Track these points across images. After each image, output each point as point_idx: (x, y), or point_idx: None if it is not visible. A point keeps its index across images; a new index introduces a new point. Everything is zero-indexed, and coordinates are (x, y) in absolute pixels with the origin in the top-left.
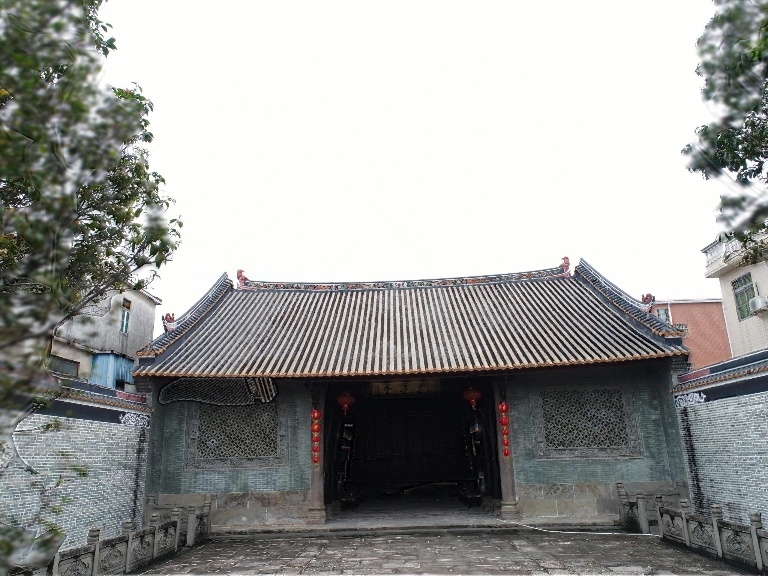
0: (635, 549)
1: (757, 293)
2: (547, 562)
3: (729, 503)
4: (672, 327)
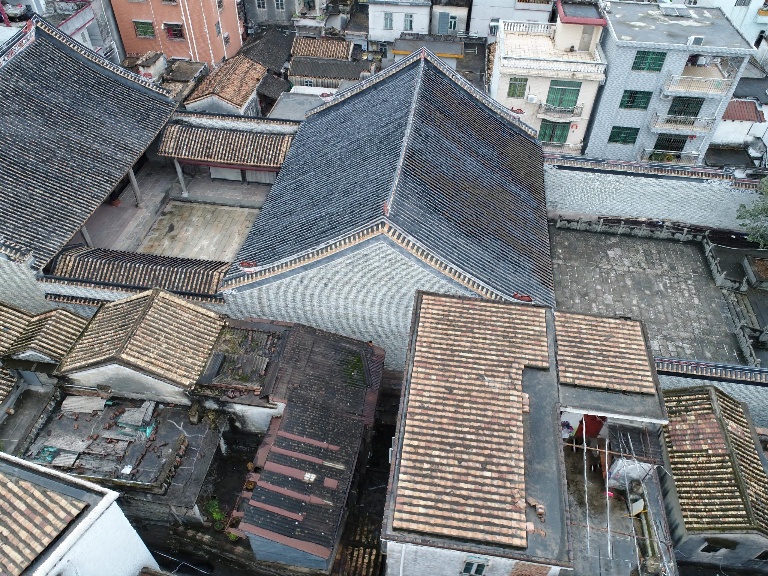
0: (575, 240)
1: (528, 90)
2: (602, 266)
3: (552, 201)
4: (535, 131)
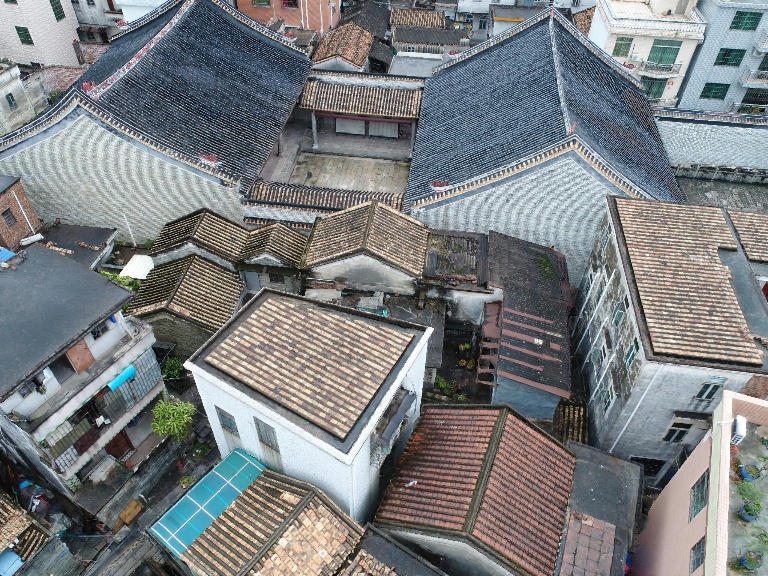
0: None
1: (633, 49)
2: None
3: None
4: None
